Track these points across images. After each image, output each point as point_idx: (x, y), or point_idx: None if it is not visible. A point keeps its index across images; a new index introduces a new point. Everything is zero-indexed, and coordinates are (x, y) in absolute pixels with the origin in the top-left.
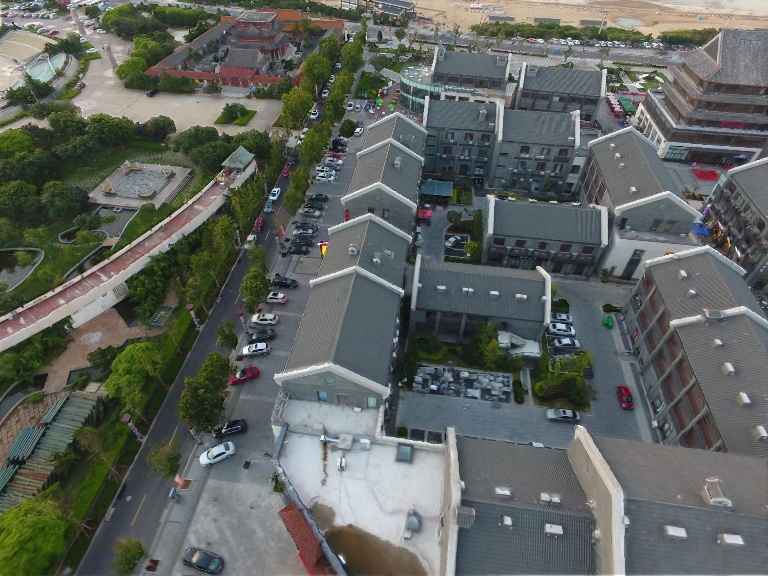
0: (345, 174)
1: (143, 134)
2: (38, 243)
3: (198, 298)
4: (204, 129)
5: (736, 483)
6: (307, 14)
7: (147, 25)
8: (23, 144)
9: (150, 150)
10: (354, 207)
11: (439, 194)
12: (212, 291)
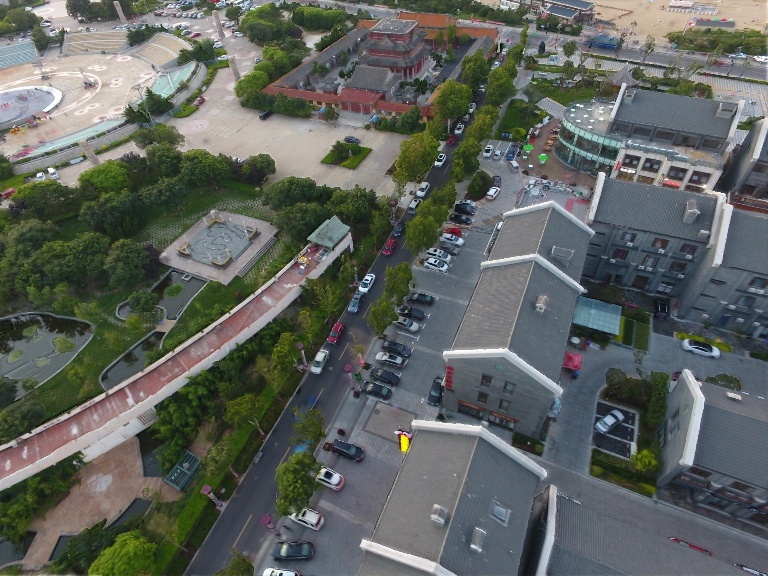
0: (464, 261)
1: (238, 175)
2: (89, 320)
3: (223, 470)
4: (299, 183)
5: None
6: (456, 19)
7: (281, 29)
8: (117, 179)
9: (243, 194)
10: (461, 367)
11: (597, 327)
12: (252, 443)
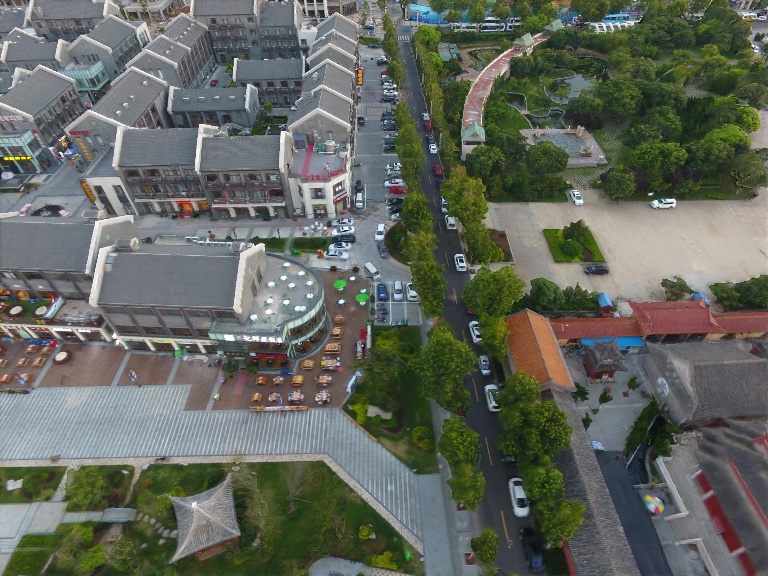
0: (378, 176)
1: None
2: None
3: None
4: (537, 148)
5: (220, 2)
6: None
7: None
8: None
9: None
10: None
11: None
12: None
